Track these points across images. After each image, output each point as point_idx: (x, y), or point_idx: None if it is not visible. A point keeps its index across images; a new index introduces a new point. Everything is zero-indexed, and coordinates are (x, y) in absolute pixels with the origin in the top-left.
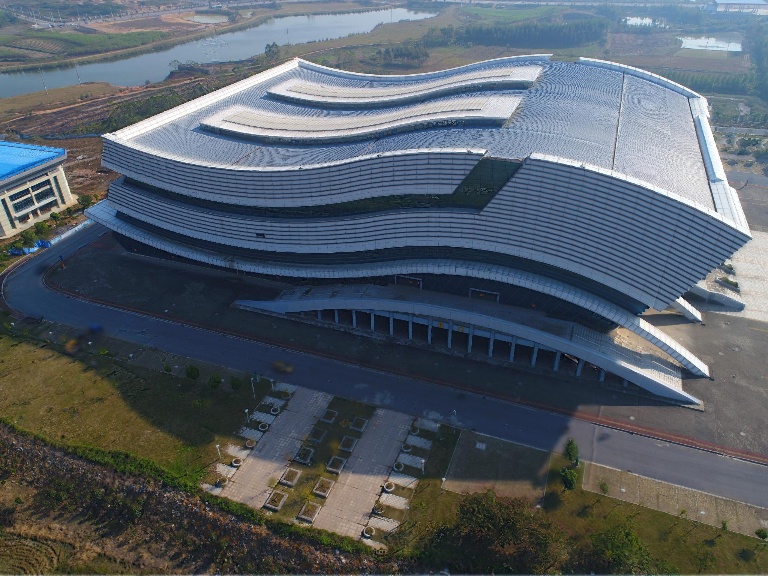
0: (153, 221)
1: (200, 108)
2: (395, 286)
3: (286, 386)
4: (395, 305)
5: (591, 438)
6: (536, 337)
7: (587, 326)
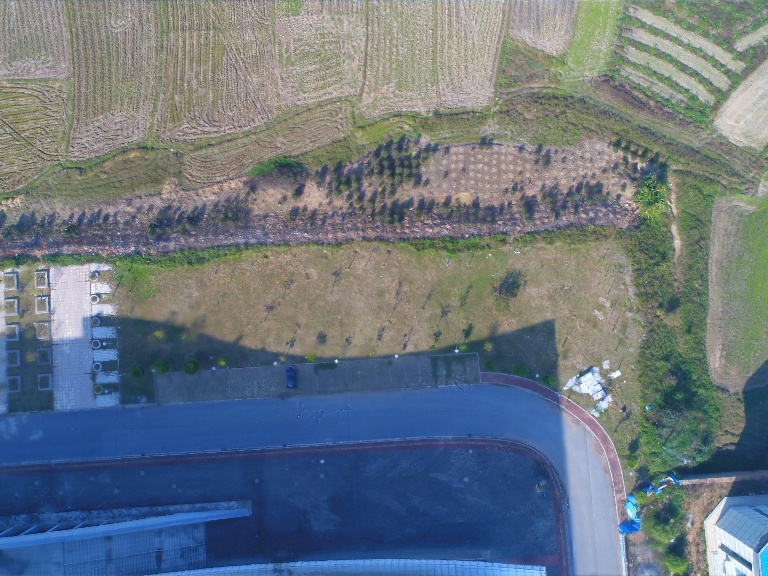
0: None
1: None
2: None
3: (107, 403)
4: None
5: None
6: None
7: None
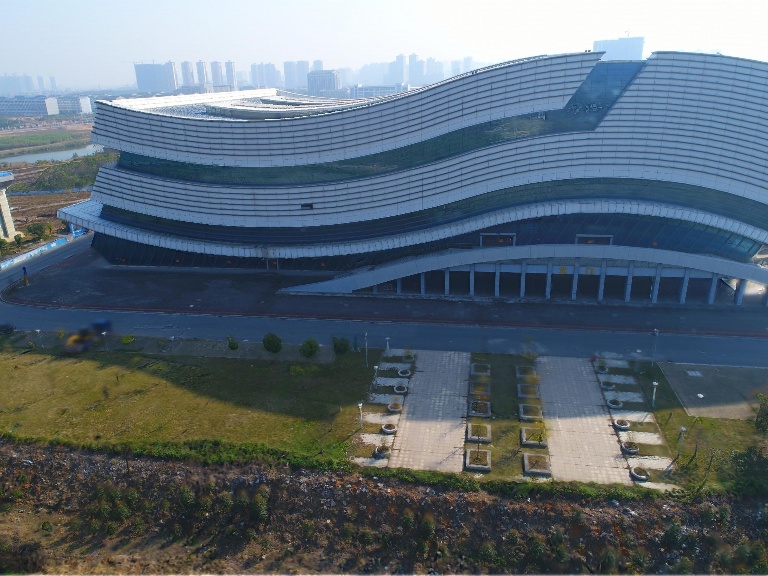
0: (156, 211)
1: (195, 103)
2: (482, 247)
3: (400, 351)
4: (506, 251)
5: None
6: (688, 261)
7: (723, 256)
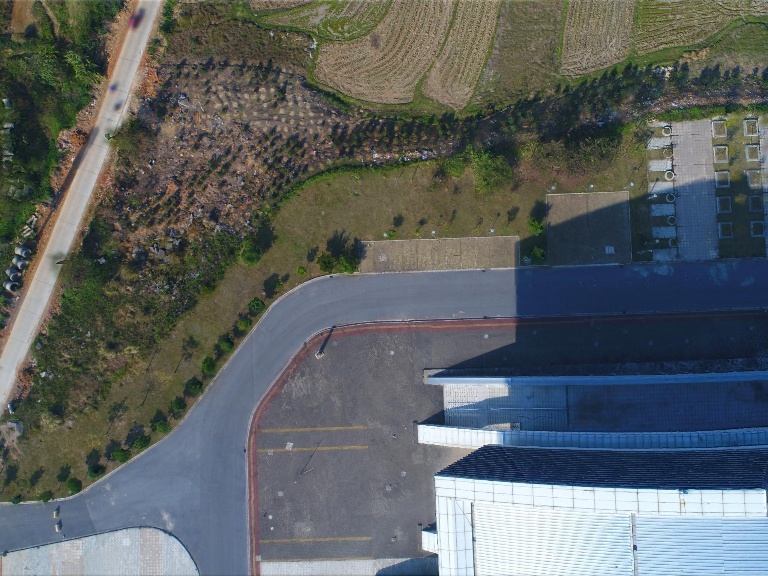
0: None
1: None
2: None
3: None
4: None
5: (519, 297)
6: None
7: None
